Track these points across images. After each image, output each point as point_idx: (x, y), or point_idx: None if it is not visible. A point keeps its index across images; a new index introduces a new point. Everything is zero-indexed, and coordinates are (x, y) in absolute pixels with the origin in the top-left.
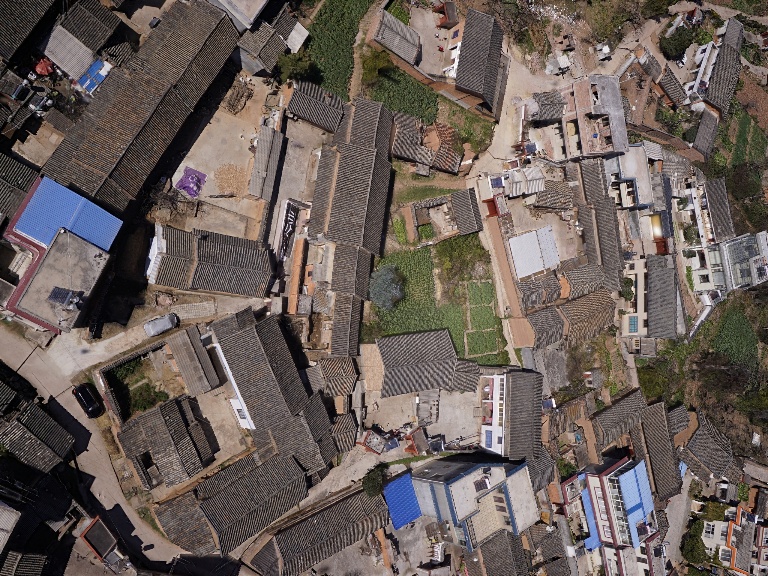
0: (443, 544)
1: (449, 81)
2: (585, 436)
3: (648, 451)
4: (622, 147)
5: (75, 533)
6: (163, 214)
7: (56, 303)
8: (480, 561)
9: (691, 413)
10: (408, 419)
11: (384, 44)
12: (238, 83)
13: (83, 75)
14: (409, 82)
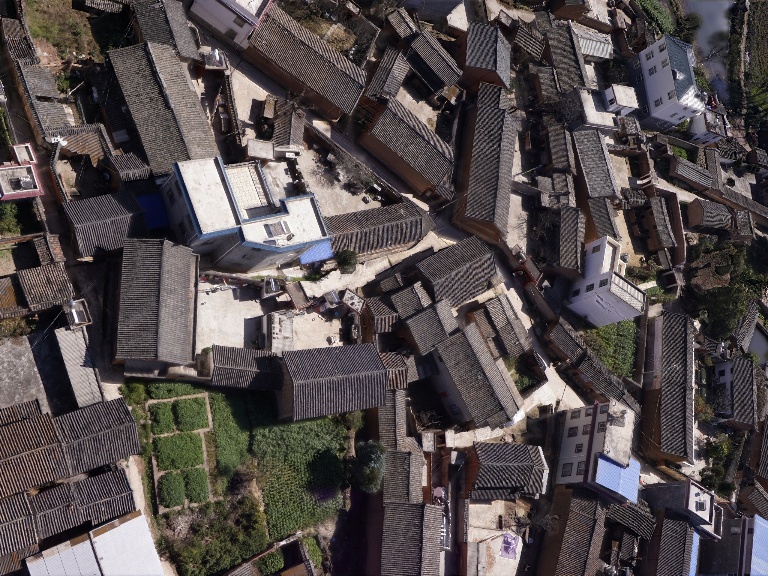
0: None
1: None
2: None
3: None
4: None
5: None
6: (520, 512)
7: None
8: None
9: None
10: None
11: None
12: None
13: None
14: None
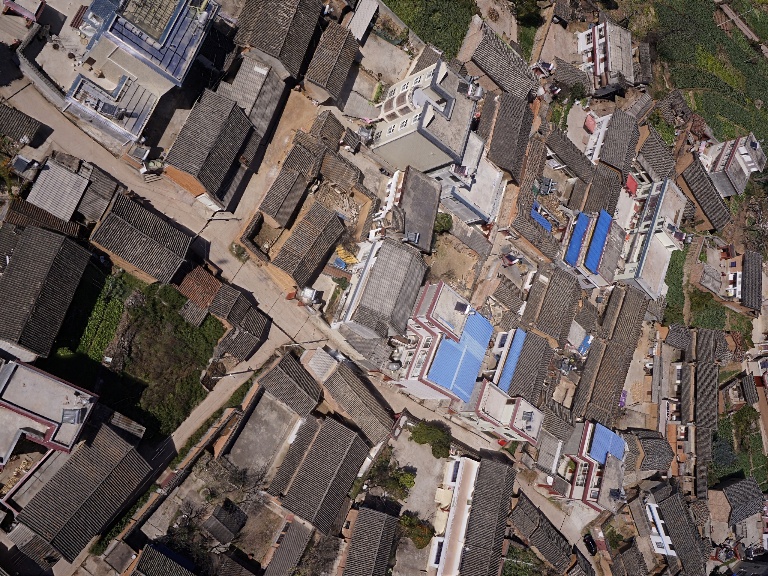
0: None
1: (735, 300)
2: None
3: None
4: None
5: None
6: None
7: (611, 498)
8: None
9: None
10: (727, 535)
11: (705, 285)
12: None
13: (580, 345)
14: None
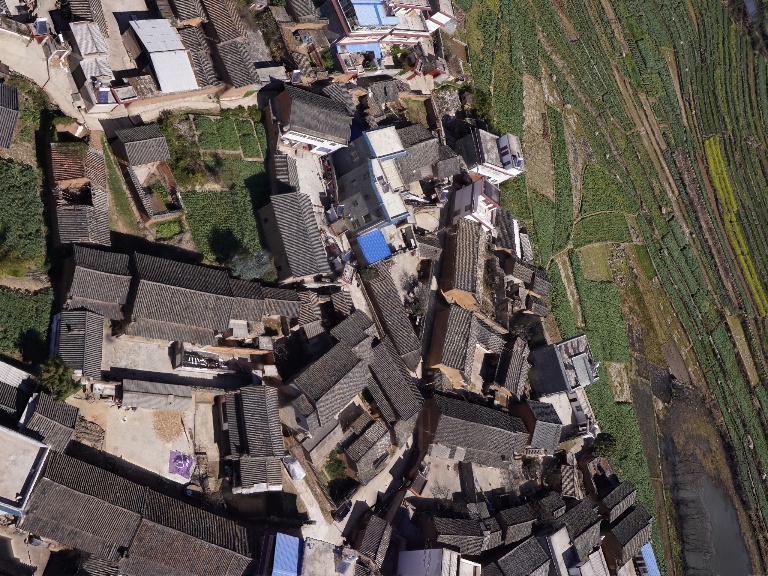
0: None
1: None
2: (303, 29)
3: None
4: None
5: (406, 497)
6: (212, 484)
7: None
8: None
9: None
10: None
11: None
12: None
13: None
14: None
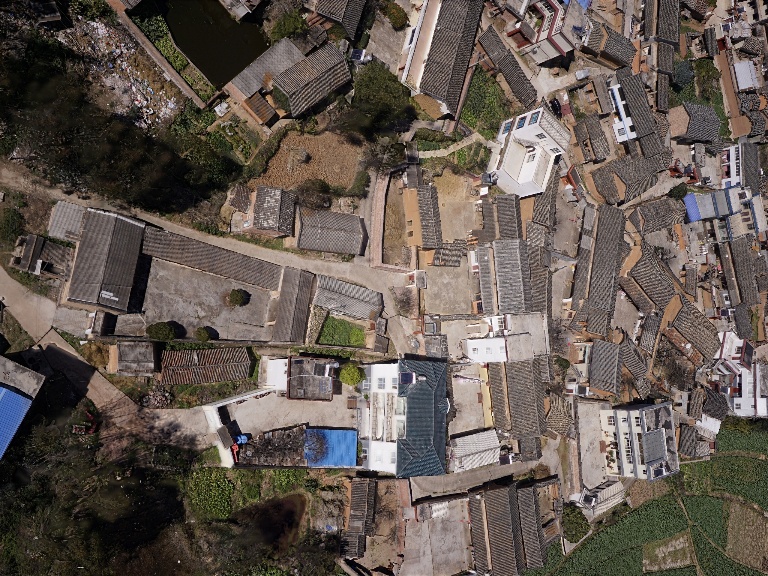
0: (708, 244)
1: None
2: None
3: None
4: None
5: None
6: None
7: (574, 34)
8: (729, 258)
9: None
10: (687, 164)
11: None
12: None
13: None
14: None
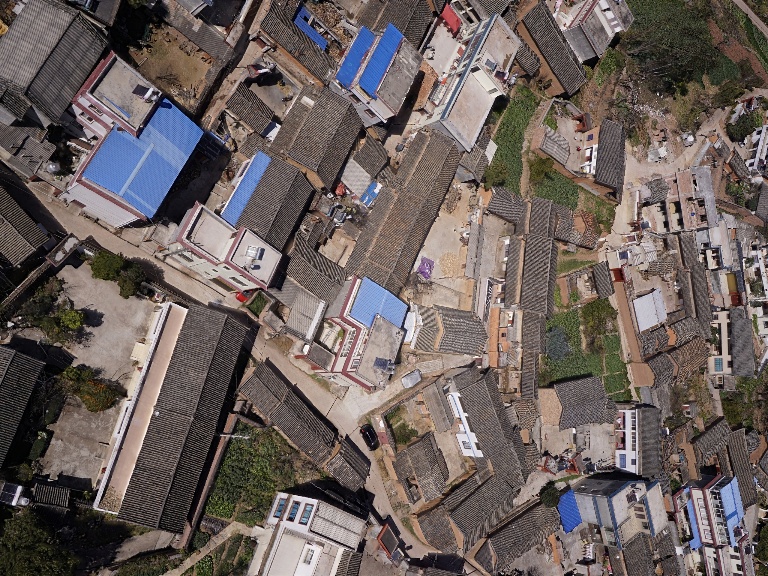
0: (594, 545)
1: (589, 176)
2: (686, 457)
3: (732, 468)
4: (714, 223)
5: (366, 537)
6: None
7: (377, 369)
8: (621, 558)
9: (760, 436)
10: (567, 446)
11: (547, 152)
12: (452, 189)
13: (364, 194)
14: (560, 178)
